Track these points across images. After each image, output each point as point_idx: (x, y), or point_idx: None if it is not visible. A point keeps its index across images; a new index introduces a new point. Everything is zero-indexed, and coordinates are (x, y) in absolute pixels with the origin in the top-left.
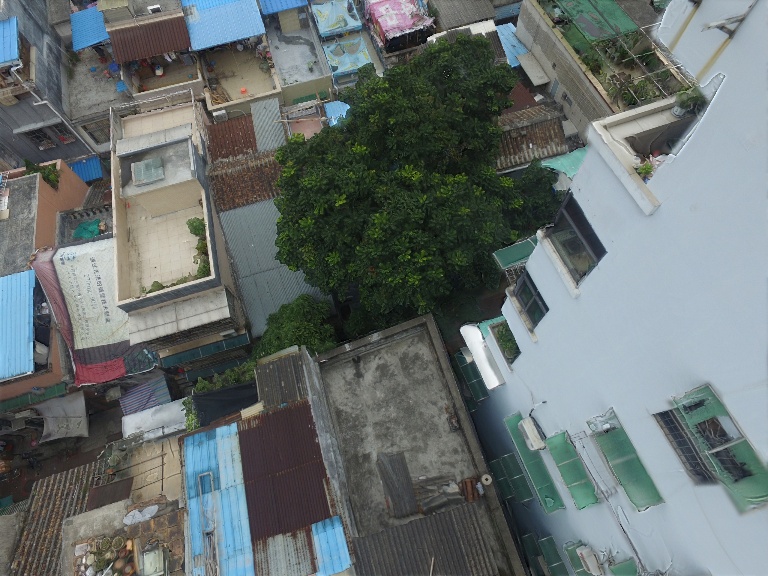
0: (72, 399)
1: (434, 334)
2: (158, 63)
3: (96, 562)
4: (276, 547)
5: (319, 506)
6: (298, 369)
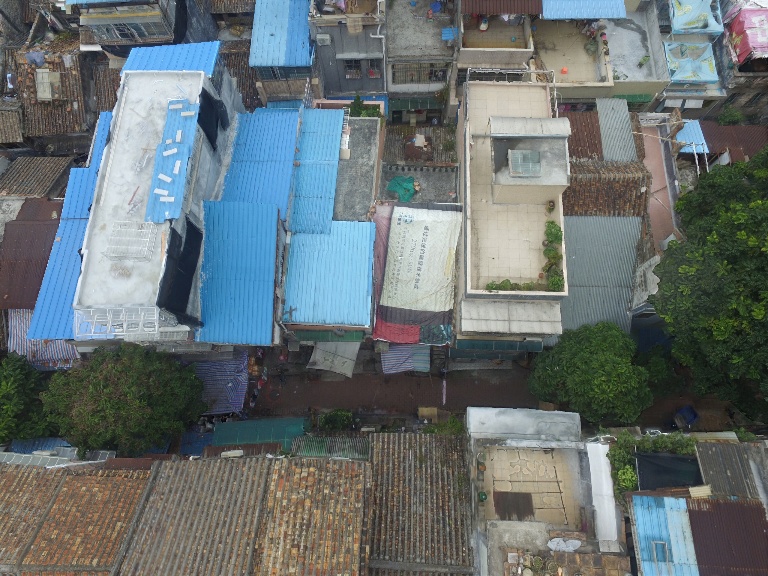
0: None
1: None
2: (485, 16)
3: None
4: None
5: None
6: (743, 462)
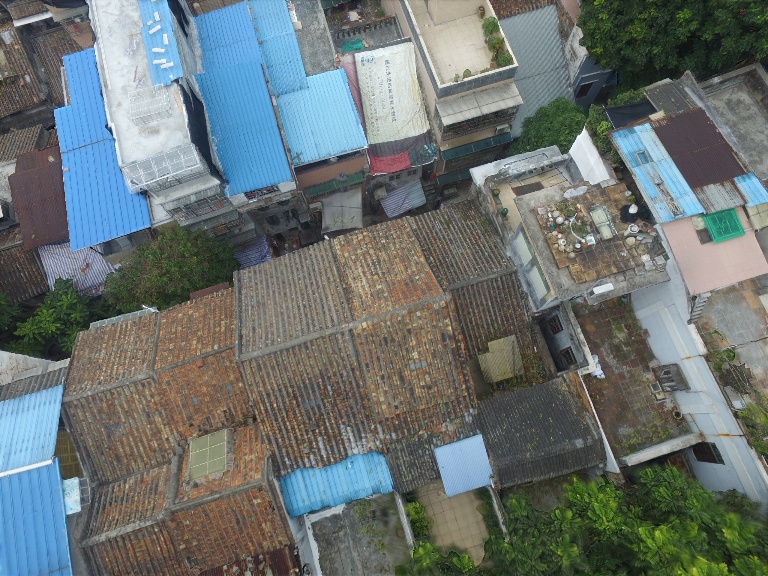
0: (351, 195)
1: (765, 77)
2: None
3: None
4: (711, 191)
5: (735, 168)
6: (681, 91)
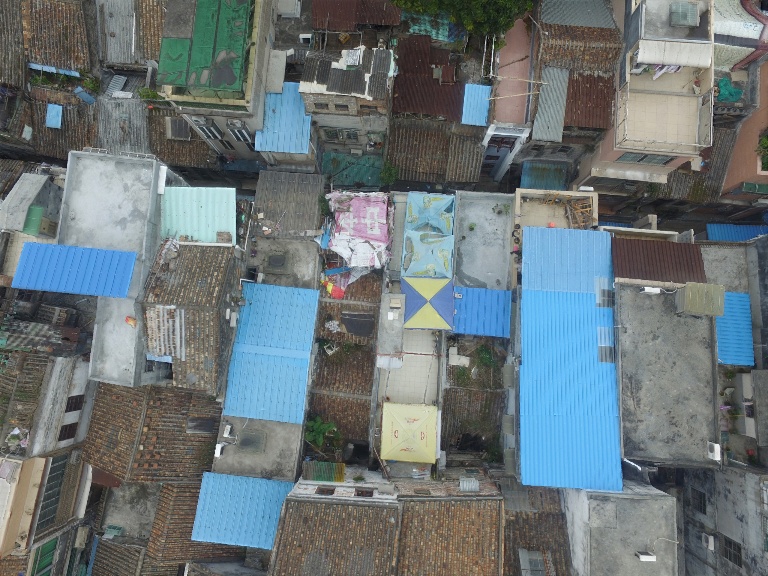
0: None
1: None
2: None
3: None
4: None
5: None
6: None
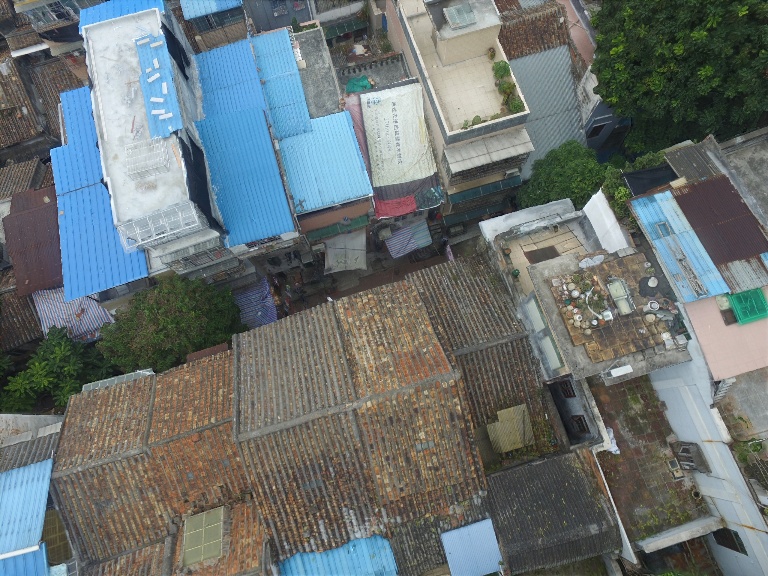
0: (355, 236)
1: None
2: None
3: None
4: (737, 268)
5: (761, 243)
6: (703, 155)
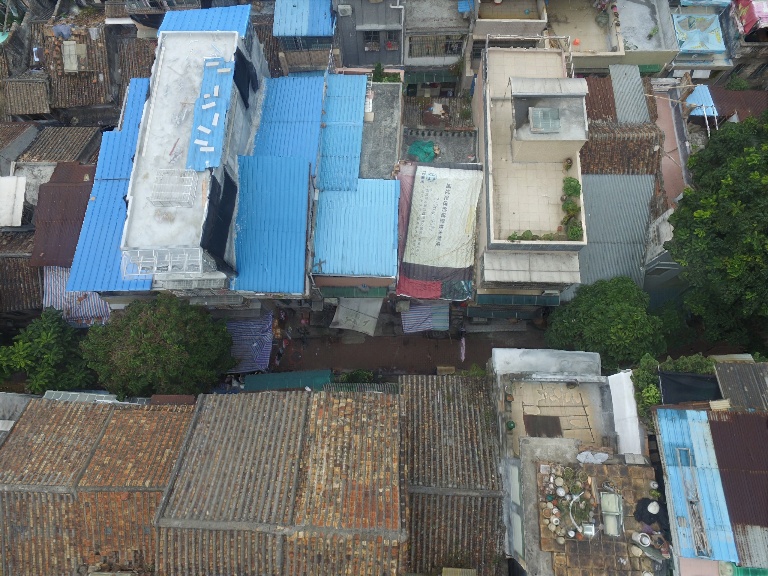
0: (371, 300)
1: None
2: None
3: (570, 487)
4: (755, 535)
5: None
6: (759, 379)
